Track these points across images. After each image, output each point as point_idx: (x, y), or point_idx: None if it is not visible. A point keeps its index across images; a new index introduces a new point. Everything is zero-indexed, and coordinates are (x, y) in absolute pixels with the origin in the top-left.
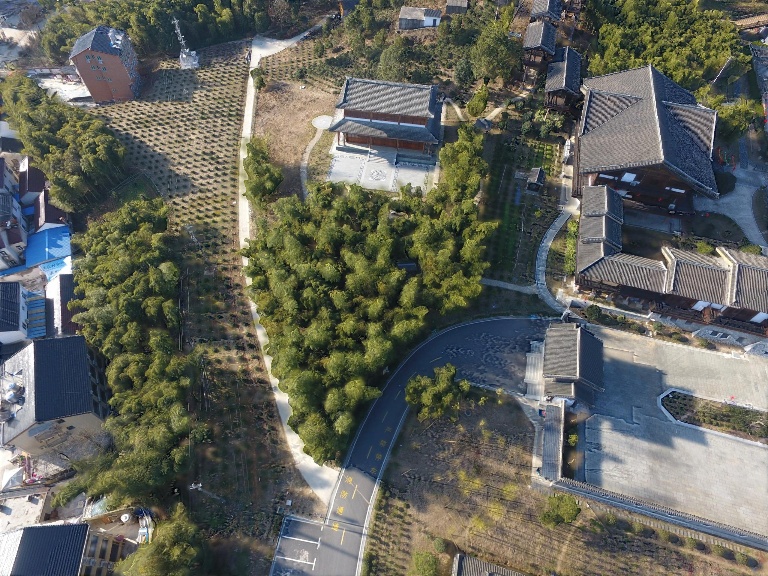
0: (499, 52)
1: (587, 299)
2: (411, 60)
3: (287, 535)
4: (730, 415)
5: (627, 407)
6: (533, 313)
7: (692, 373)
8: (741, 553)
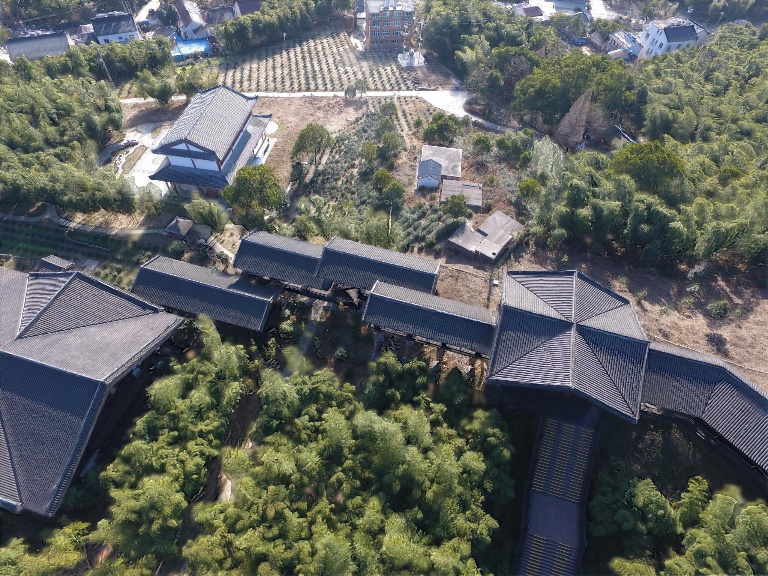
0: None
1: None
2: None
3: None
4: None
5: None
6: None
7: None
8: None
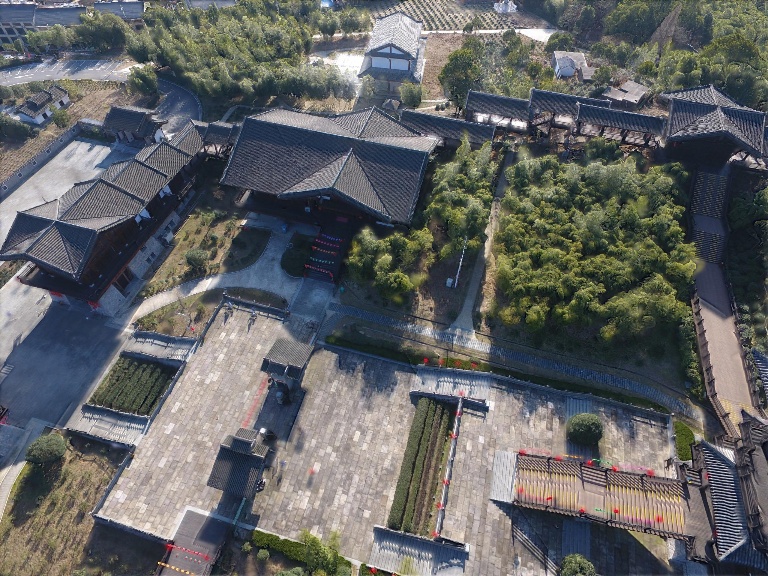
0: None
1: None
2: None
3: (114, 62)
4: None
5: (108, 166)
6: None
7: None
8: None
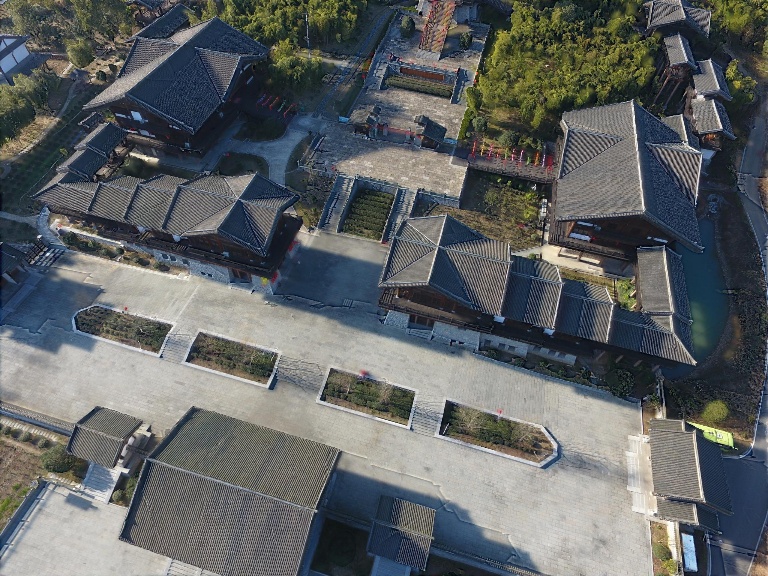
0: (86, 4)
1: (75, 228)
2: (67, 19)
3: None
4: (131, 326)
5: (42, 319)
6: (20, 240)
7: (129, 291)
8: (45, 439)
